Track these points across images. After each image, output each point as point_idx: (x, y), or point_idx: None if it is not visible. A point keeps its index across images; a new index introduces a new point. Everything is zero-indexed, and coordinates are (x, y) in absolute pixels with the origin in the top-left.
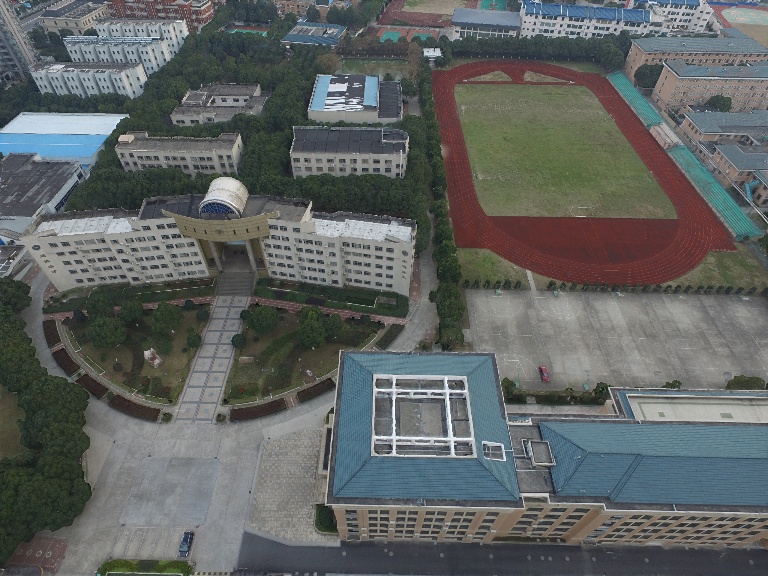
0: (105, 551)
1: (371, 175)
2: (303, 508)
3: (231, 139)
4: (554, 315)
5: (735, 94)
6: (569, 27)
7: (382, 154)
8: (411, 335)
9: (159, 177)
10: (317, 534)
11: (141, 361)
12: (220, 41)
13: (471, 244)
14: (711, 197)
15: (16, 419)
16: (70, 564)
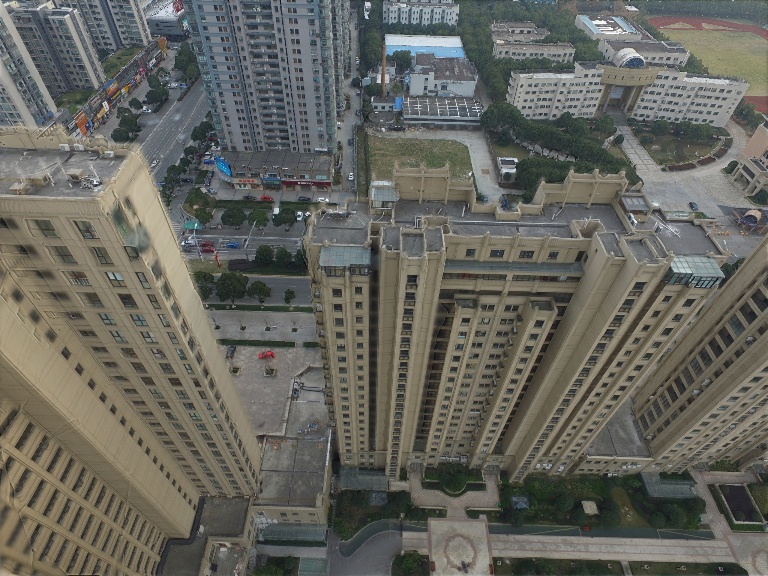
0: None
1: None
2: (740, 198)
3: (566, 45)
4: None
5: None
6: None
7: (675, 53)
8: (739, 143)
9: (538, 63)
10: (756, 206)
11: None
12: None
13: None
14: None
15: None
16: None
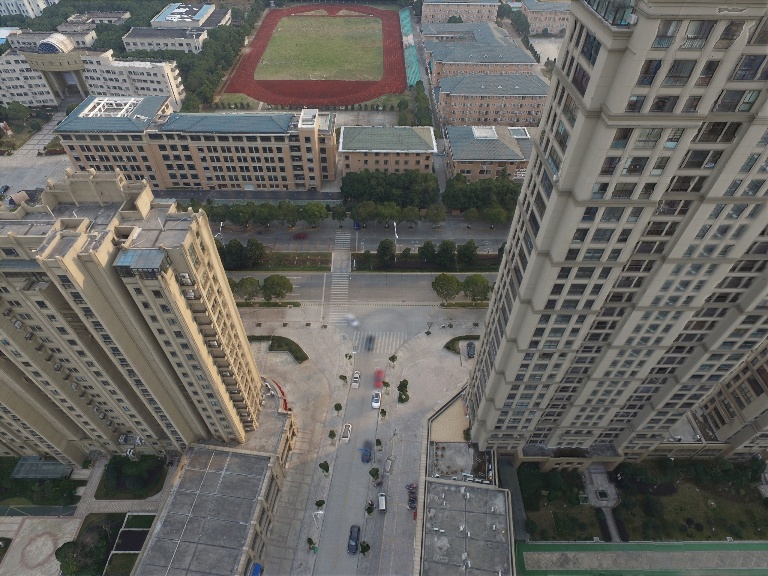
0: None
1: (172, 50)
2: None
3: (87, 33)
4: None
5: (468, 16)
6: None
7: (182, 38)
8: None
9: None
10: None
11: (1, 135)
12: None
13: (234, 91)
14: (409, 70)
15: None
16: None
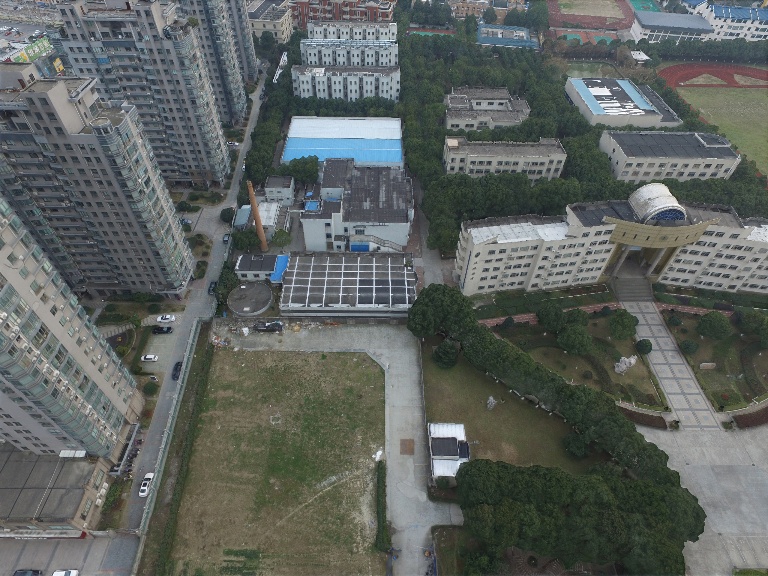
0: (724, 561)
1: (717, 180)
2: None
3: (553, 144)
4: None
5: None
6: (757, 30)
7: (718, 159)
8: None
9: (509, 182)
10: None
11: (604, 368)
12: (422, 44)
13: None
14: None
15: (526, 428)
16: (701, 574)
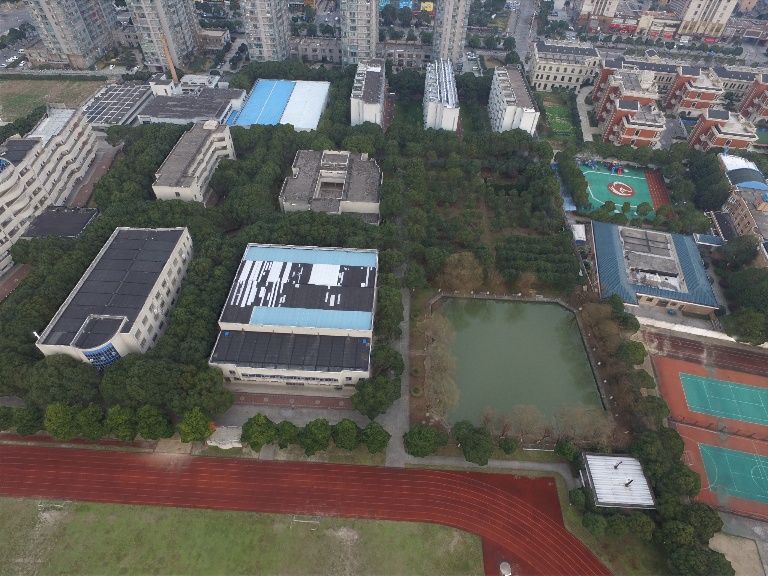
0: None
1: (33, 308)
2: None
3: (183, 184)
4: None
5: None
6: None
7: None
8: None
9: None
10: None
11: None
12: None
13: None
14: None
15: None
16: None
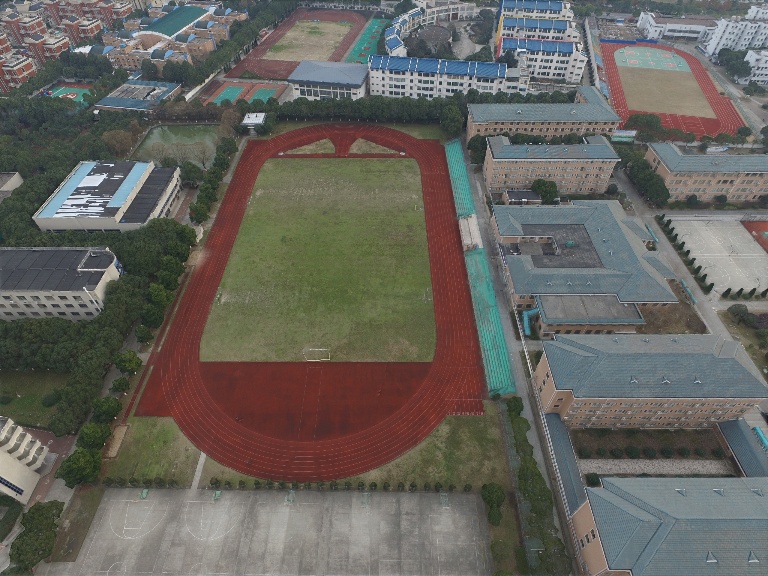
0: None
1: (40, 322)
2: None
3: None
4: (197, 533)
5: (565, 175)
6: (420, 82)
7: (64, 291)
8: None
9: None
10: None
11: None
12: (21, 109)
13: (154, 410)
14: (483, 328)
15: None
16: None
